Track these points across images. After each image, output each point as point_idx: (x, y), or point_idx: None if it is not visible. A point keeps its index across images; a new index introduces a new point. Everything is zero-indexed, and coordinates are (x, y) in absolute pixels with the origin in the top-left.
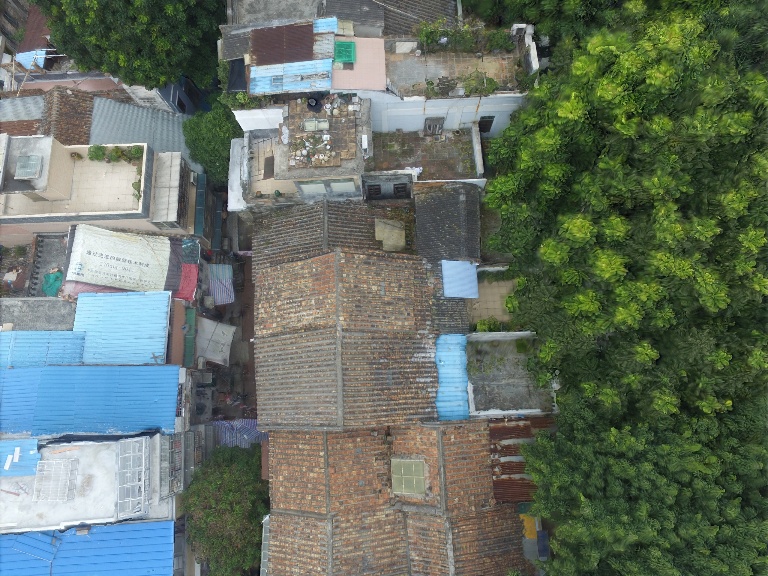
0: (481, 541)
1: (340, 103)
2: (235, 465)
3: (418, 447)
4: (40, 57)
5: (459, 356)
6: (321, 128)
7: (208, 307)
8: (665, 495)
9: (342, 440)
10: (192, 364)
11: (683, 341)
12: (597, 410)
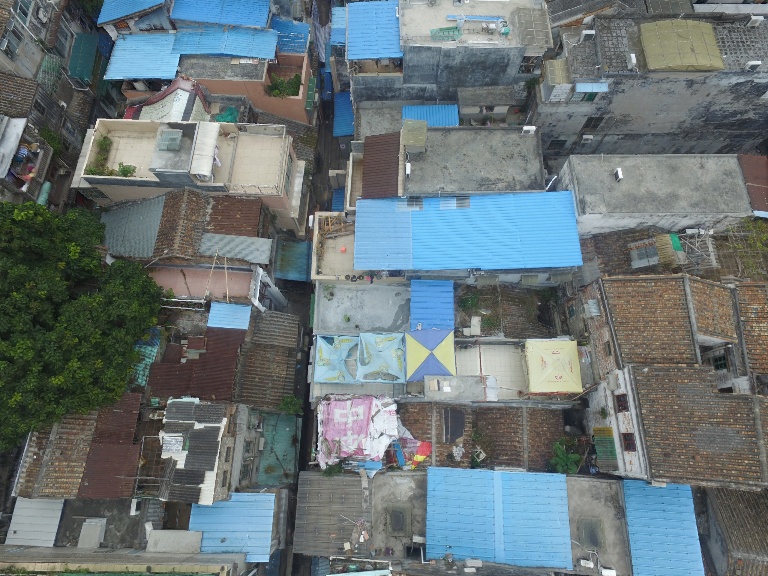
0: None
1: None
2: None
3: None
4: (199, 301)
5: None
6: None
7: None
8: None
9: None
10: None
11: None
12: None
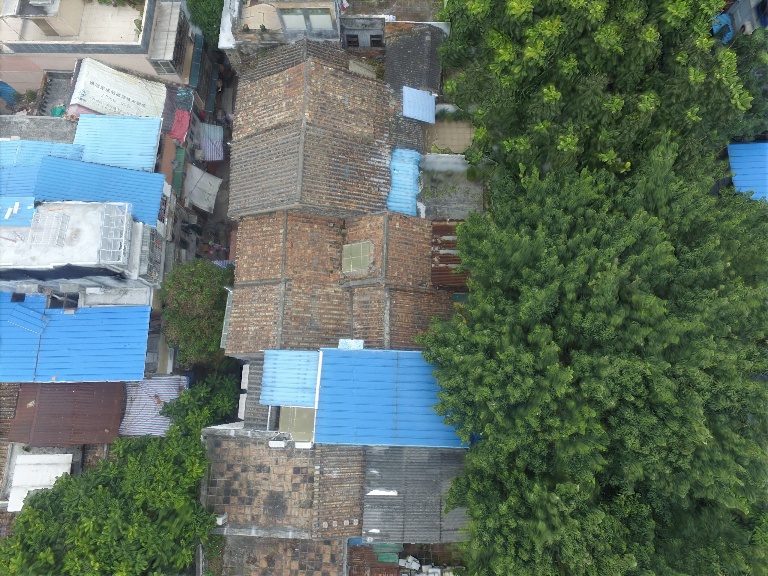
0: (416, 315)
1: None
2: (208, 260)
3: (367, 233)
4: None
5: (412, 168)
6: None
7: (198, 159)
8: (561, 225)
9: (301, 224)
10: (178, 195)
11: (583, 85)
12: (519, 184)
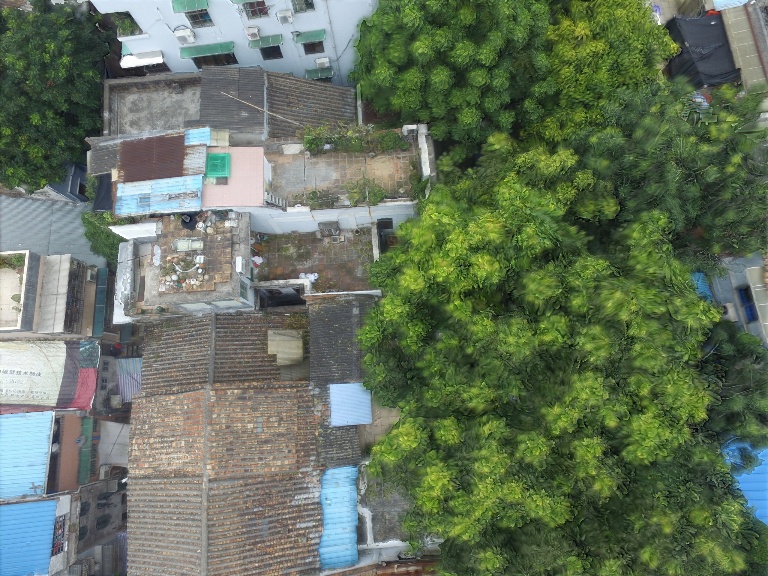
0: None
1: (215, 220)
2: None
3: None
4: None
5: (348, 492)
6: (195, 247)
7: (115, 407)
8: None
9: None
10: (87, 480)
11: (536, 544)
12: None
